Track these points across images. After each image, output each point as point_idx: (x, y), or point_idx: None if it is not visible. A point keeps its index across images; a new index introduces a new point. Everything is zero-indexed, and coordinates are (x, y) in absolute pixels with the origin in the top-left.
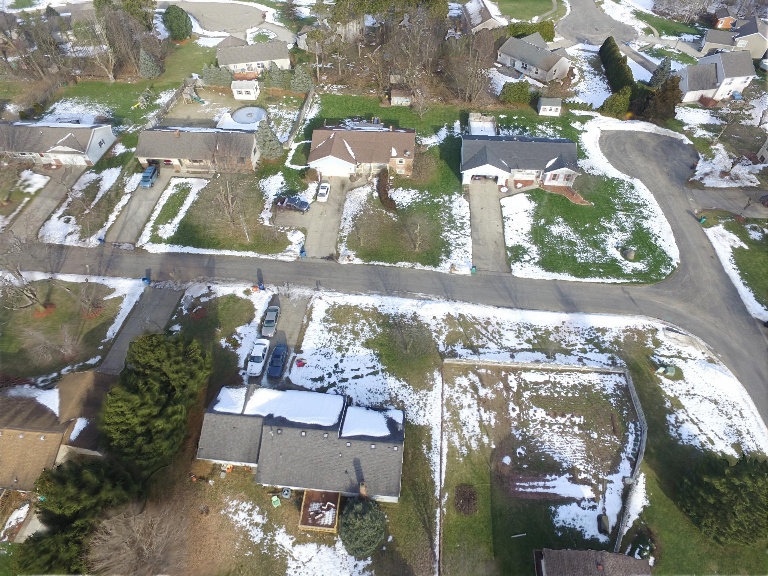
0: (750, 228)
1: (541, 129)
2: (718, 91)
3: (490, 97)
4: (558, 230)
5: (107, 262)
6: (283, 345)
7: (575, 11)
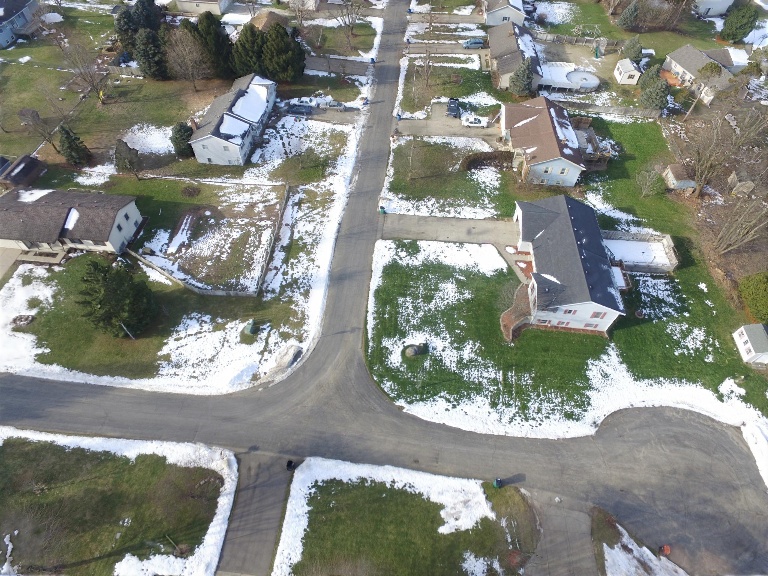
0: (492, 567)
1: (693, 332)
2: None
3: None
4: (448, 290)
5: (391, 47)
6: (310, 109)
7: None
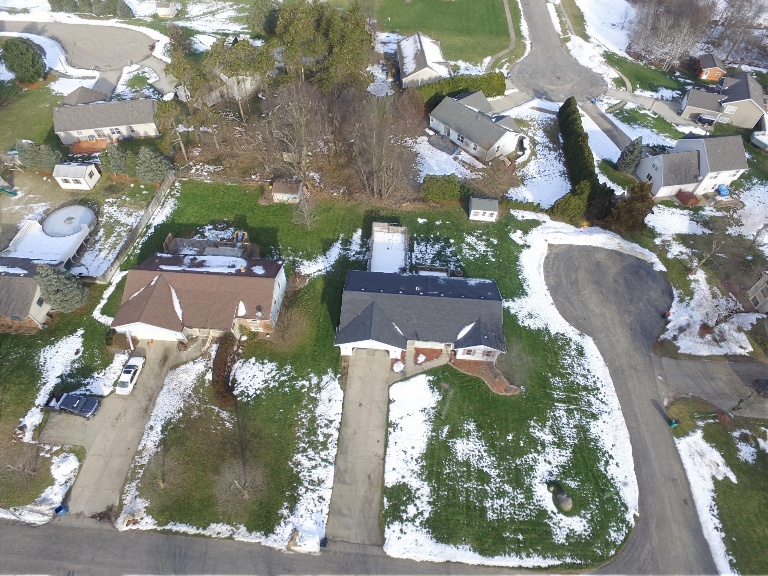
0: (739, 438)
1: (470, 242)
2: (700, 185)
3: (410, 187)
4: (466, 449)
5: None
6: None
7: (535, 50)
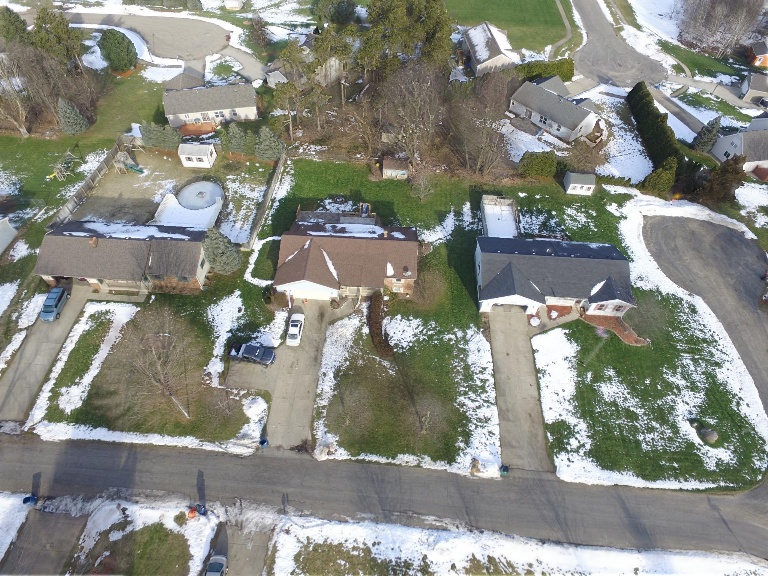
0: None
1: (571, 214)
2: None
3: (505, 165)
4: (611, 392)
5: None
6: None
7: (592, 39)
